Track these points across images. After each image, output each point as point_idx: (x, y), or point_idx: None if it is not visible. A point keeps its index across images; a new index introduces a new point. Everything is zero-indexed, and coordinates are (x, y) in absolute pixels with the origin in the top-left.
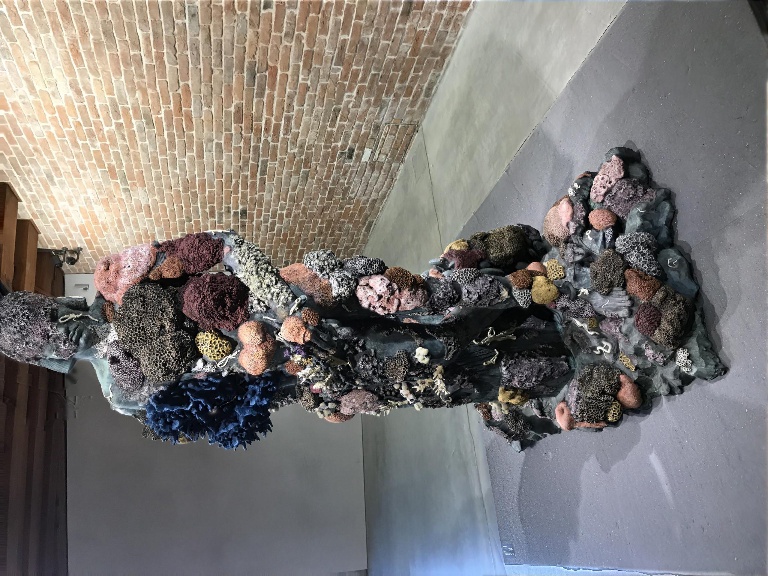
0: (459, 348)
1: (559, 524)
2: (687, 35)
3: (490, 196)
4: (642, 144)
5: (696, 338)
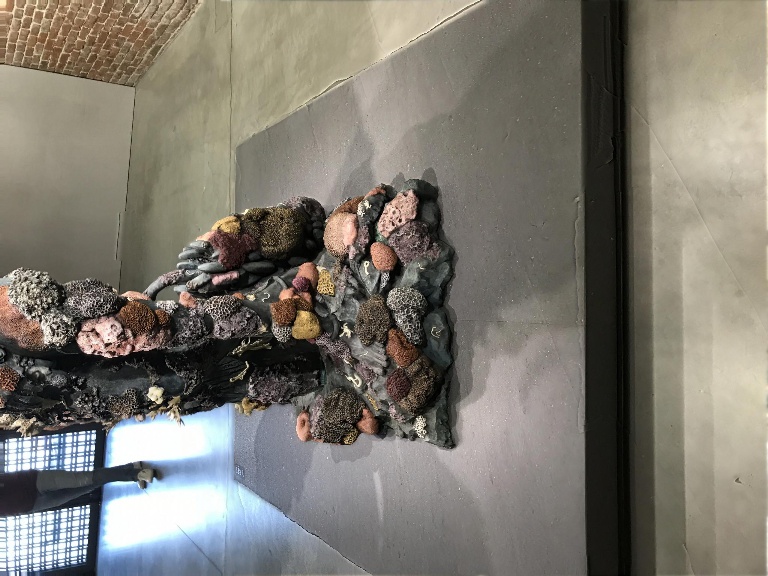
0: (202, 380)
1: (287, 478)
2: (516, 97)
3: (286, 122)
4: (443, 182)
5: (436, 411)
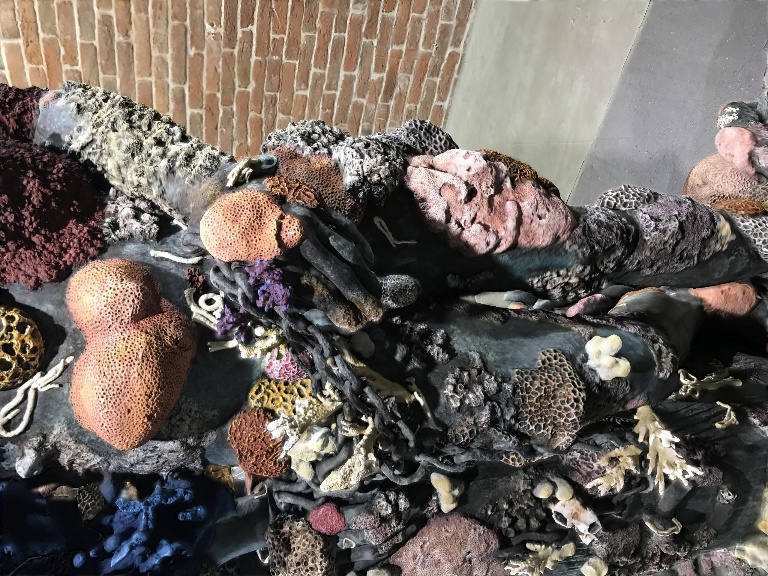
0: (674, 355)
1: None
2: None
3: None
4: None
5: None
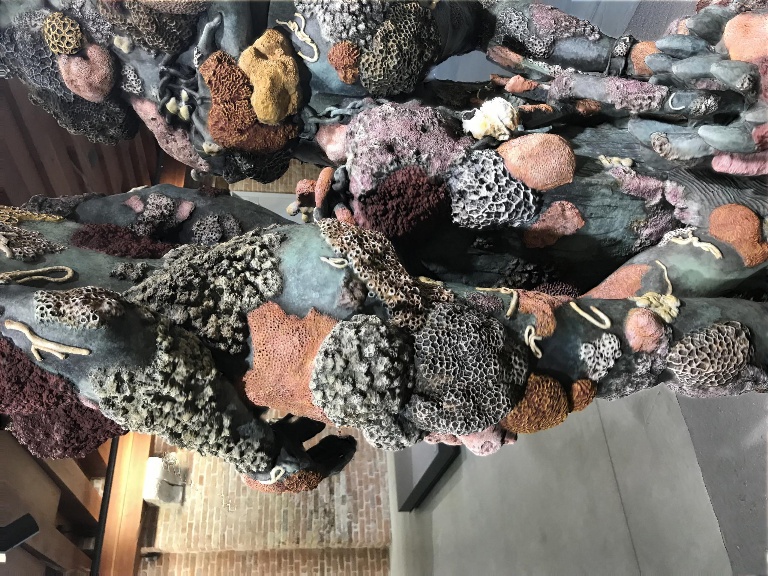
0: None
1: None
2: None
3: None
4: None
5: None
